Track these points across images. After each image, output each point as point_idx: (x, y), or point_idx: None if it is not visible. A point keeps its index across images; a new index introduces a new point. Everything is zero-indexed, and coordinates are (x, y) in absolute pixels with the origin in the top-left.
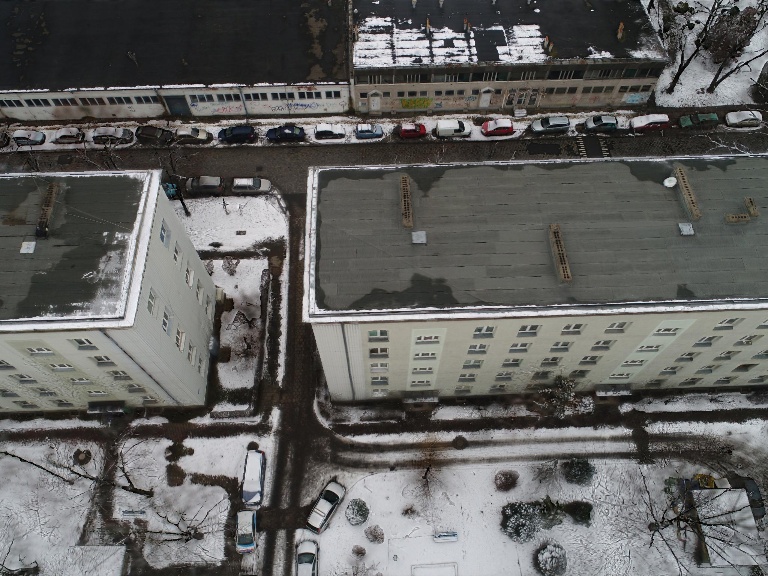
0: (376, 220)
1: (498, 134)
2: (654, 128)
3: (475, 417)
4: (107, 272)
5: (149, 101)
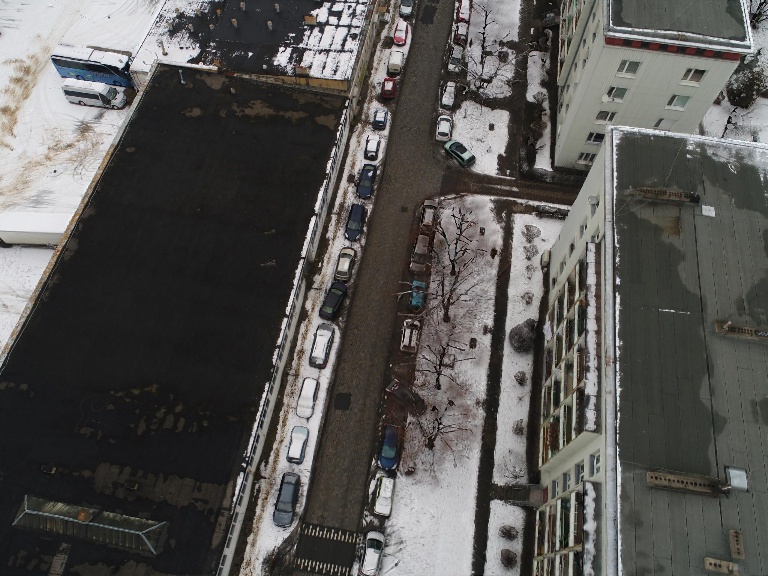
0: (666, 1)
1: None
2: None
3: None
4: (728, 156)
5: (299, 288)
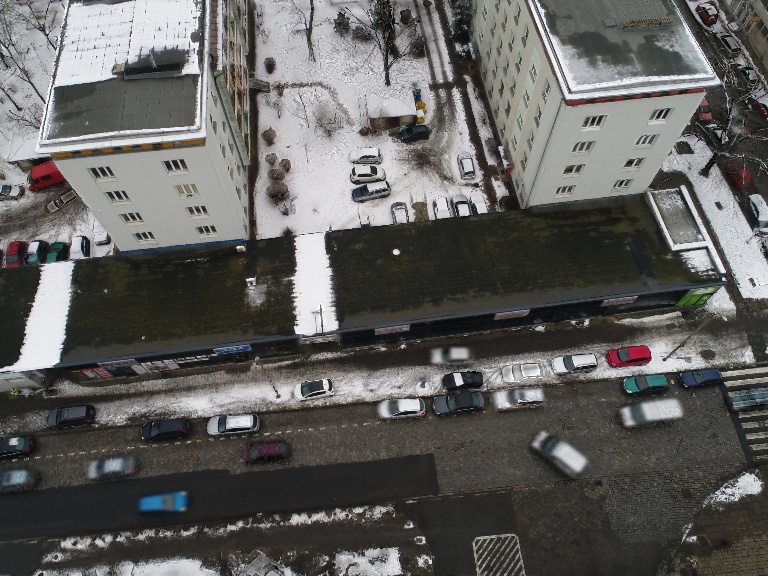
0: None
1: (701, 15)
2: (762, 114)
3: (445, 8)
4: None
5: None
